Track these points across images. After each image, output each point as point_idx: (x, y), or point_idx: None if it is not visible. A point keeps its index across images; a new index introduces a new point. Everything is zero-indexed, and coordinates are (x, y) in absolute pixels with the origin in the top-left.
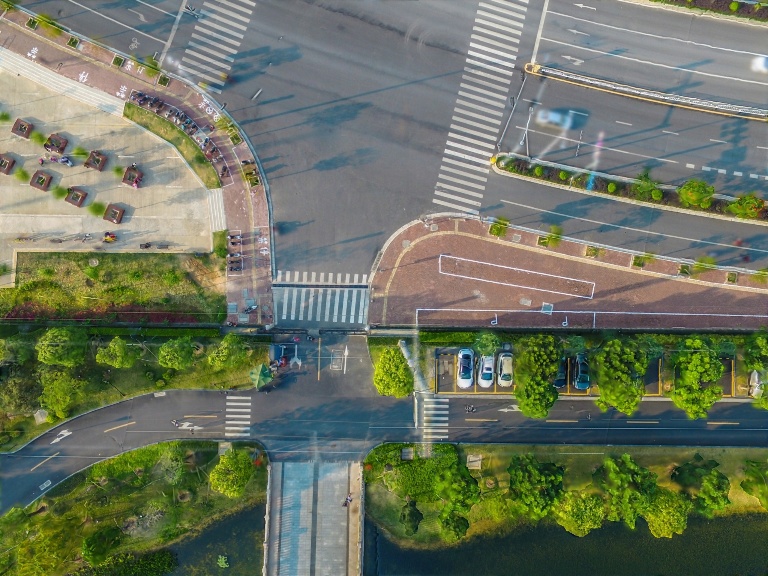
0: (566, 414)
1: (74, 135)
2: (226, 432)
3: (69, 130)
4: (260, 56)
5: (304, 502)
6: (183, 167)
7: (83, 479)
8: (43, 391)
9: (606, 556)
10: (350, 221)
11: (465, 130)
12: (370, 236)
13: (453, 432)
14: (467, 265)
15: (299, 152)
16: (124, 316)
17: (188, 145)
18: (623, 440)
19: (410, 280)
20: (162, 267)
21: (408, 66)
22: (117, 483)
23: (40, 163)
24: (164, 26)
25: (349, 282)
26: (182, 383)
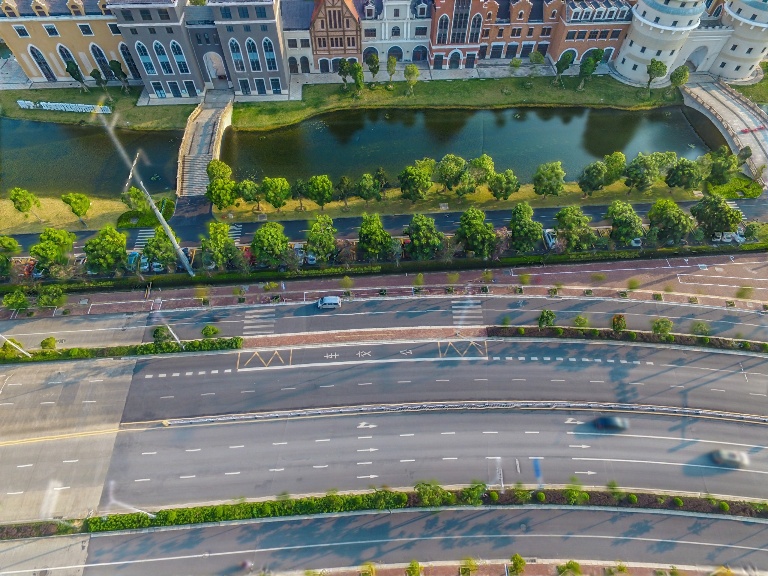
0: None
1: None
2: None
3: None
4: None
5: None
6: None
7: None
8: None
9: None
10: None
11: None
12: None
13: None
14: None
15: None
16: None
17: None
18: None
19: None
20: None
21: None
22: None
23: None
24: None
25: None
26: None
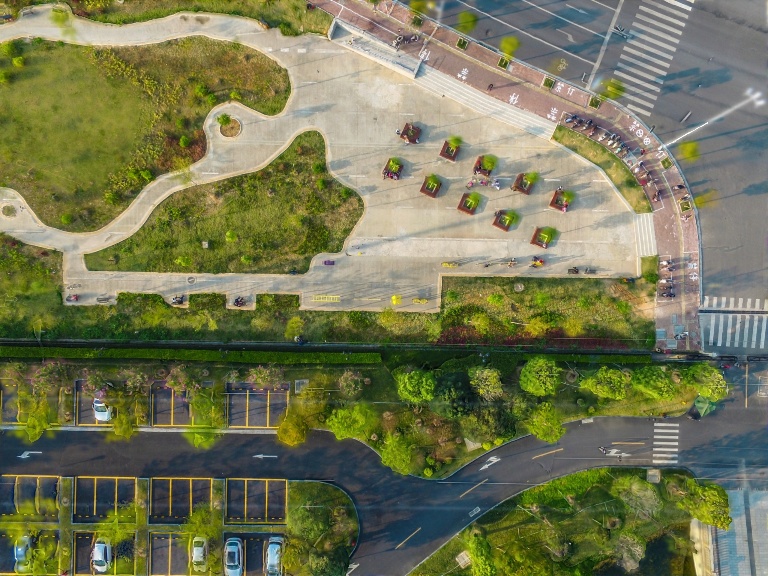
0: None
1: (500, 158)
2: (653, 459)
3: (495, 152)
4: (690, 78)
5: (738, 530)
6: (609, 191)
7: (514, 506)
8: (535, 422)
9: None
10: None
11: None
12: None
13: None
14: None
15: (728, 176)
16: (554, 342)
17: (618, 169)
18: None
19: None
20: (588, 292)
21: None
22: (548, 510)
23: (469, 186)
24: (593, 47)
25: None
26: (612, 410)
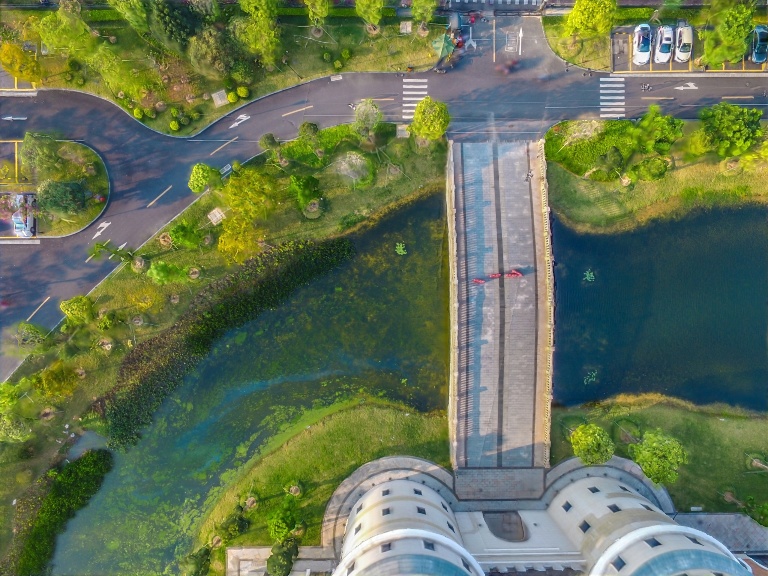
0: (742, 91)
1: None
2: (403, 115)
3: None
4: None
5: (486, 178)
6: None
7: (264, 161)
8: (246, 29)
9: None
10: None
11: None
12: None
13: (630, 110)
14: None
15: None
16: None
17: None
18: None
19: None
20: None
21: None
22: (297, 165)
23: None
24: None
25: None
26: (359, 65)
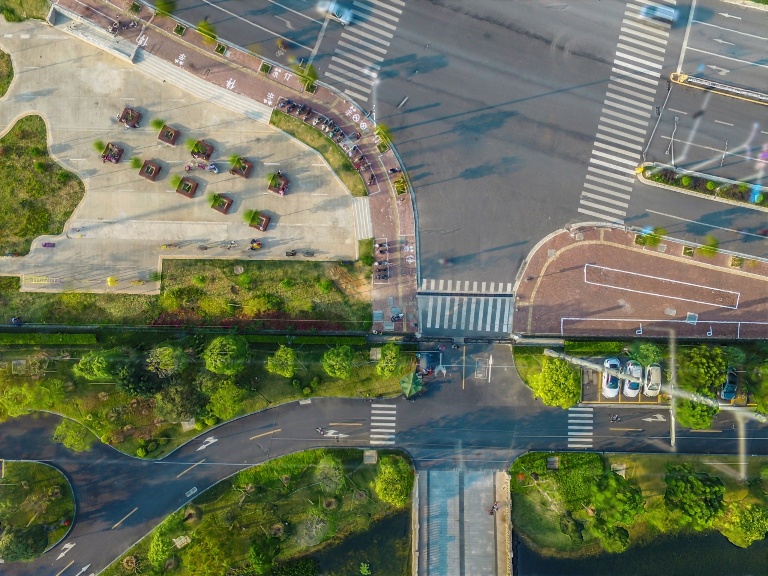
0: None
1: (220, 142)
2: (371, 440)
3: (215, 137)
4: (406, 64)
5: (451, 510)
6: (328, 175)
7: (230, 486)
8: (211, 400)
9: (746, 565)
10: (495, 230)
11: (611, 139)
12: (515, 245)
13: (597, 441)
14: (612, 274)
15: (445, 160)
16: (271, 323)
17: (335, 153)
18: (767, 450)
19: (555, 289)
20: (307, 275)
21: (554, 75)
22: (263, 490)
23: (187, 170)
24: (310, 33)
25: (494, 291)
26: (328, 391)
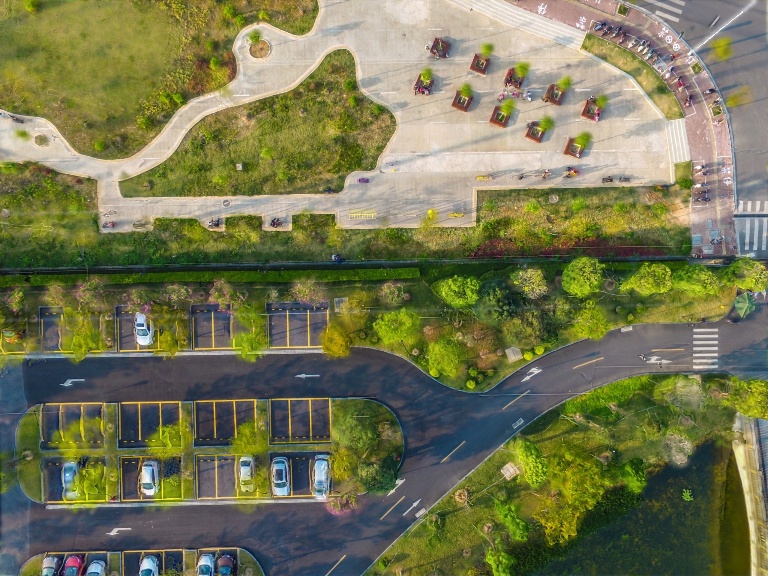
0: None
1: (530, 69)
2: (694, 365)
3: (525, 64)
4: None
5: None
6: (640, 99)
7: (557, 416)
8: (580, 319)
9: None
10: None
11: None
12: None
13: None
14: None
15: (758, 79)
16: (591, 251)
17: (649, 75)
18: None
19: None
20: (622, 201)
21: None
22: (591, 419)
23: (500, 99)
24: None
25: None
26: (651, 317)
